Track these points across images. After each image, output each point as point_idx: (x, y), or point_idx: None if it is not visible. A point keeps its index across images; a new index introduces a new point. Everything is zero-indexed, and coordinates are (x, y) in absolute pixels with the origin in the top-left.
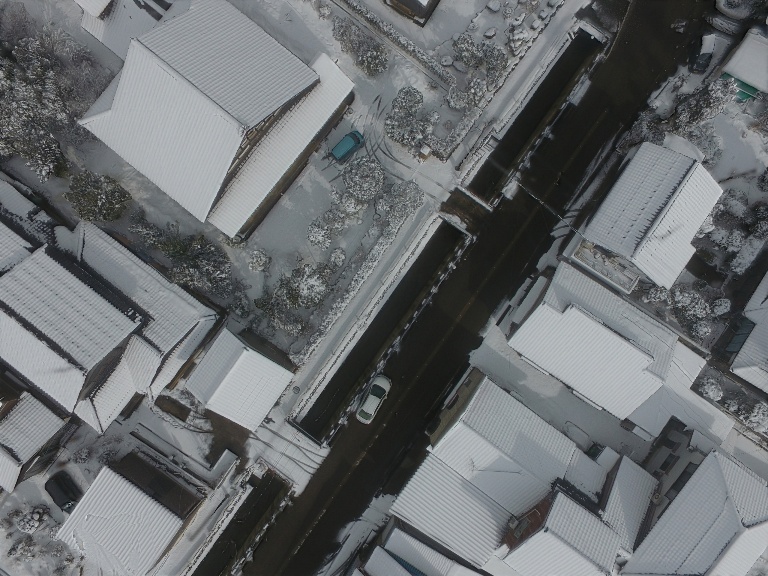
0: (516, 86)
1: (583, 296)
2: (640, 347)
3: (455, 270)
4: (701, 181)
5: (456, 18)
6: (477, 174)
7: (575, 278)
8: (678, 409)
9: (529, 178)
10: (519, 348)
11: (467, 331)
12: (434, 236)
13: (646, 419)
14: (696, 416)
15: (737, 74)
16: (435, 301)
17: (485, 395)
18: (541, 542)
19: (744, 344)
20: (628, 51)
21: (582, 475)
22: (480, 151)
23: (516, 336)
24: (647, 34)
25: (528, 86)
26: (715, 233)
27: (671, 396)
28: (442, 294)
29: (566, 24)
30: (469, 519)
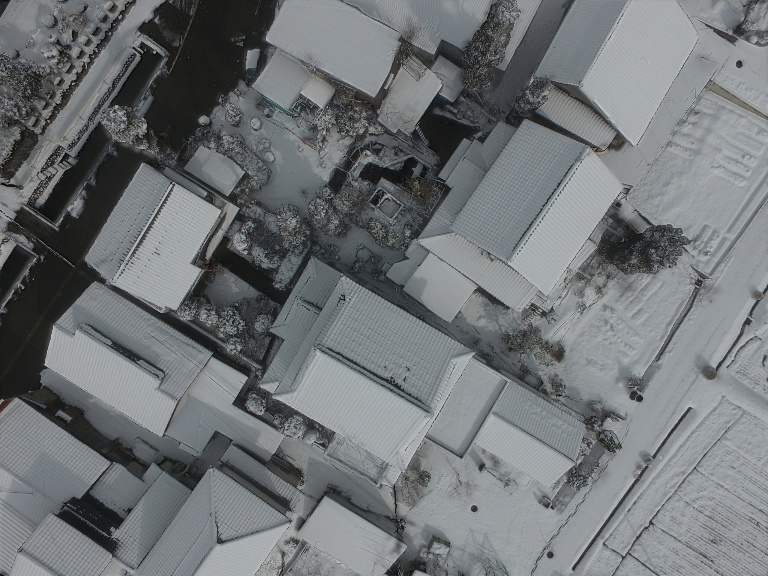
0: (81, 103)
1: (107, 317)
2: (148, 367)
3: (23, 290)
4: (185, 202)
5: (18, 34)
6: (54, 192)
7: (104, 298)
8: (219, 424)
9: (94, 196)
10: (55, 369)
11: (37, 351)
12: (12, 256)
13: (184, 435)
14: (240, 430)
15: (263, 90)
16: (5, 321)
17: (11, 417)
18: (22, 563)
19: (273, 360)
20: (190, 66)
21: (116, 492)
22: (51, 169)
23: (47, 357)
24: (208, 48)
25: (93, 103)
26: (254, 250)
27: (214, 412)
28: (11, 314)
29: (129, 39)
30: (11, 538)
